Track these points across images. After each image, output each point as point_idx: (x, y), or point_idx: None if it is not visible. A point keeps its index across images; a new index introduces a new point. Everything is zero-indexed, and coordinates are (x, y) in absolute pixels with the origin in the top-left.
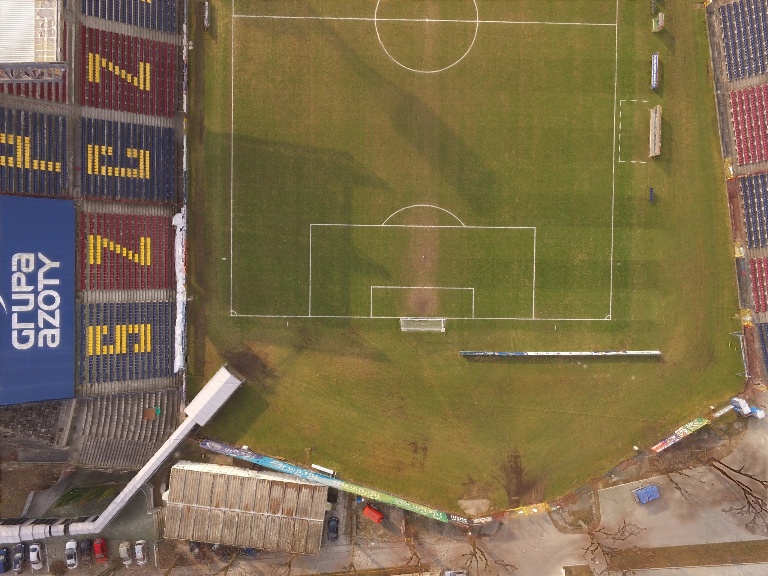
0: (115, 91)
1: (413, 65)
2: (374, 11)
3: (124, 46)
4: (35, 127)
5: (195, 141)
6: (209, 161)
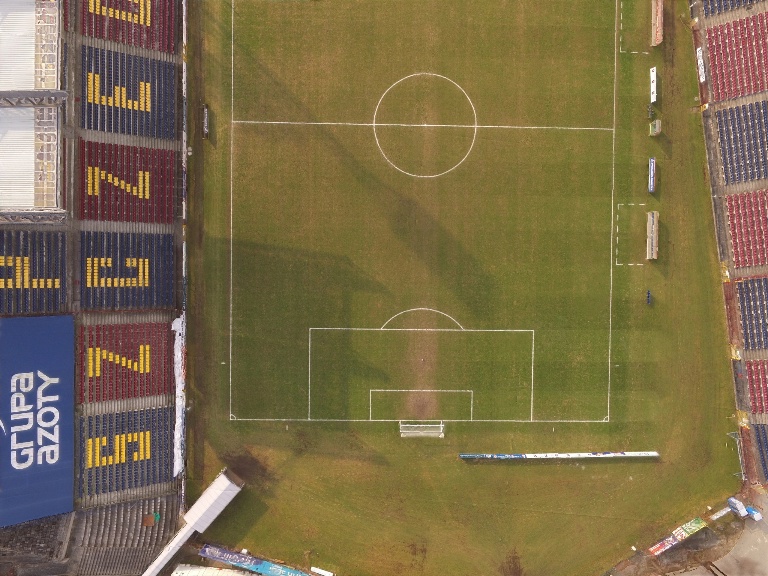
0: (114, 202)
1: (412, 170)
2: (373, 116)
3: (123, 157)
4: (34, 246)
5: (194, 246)
6: (208, 266)
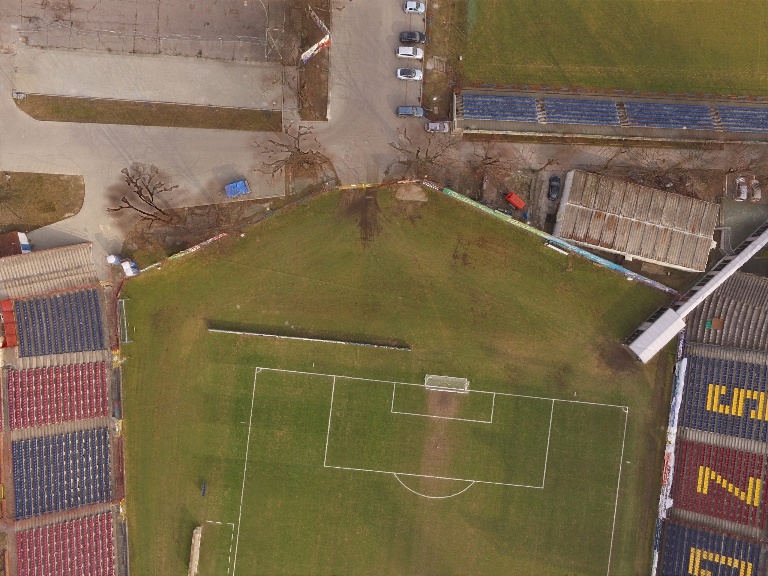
0: None
1: None
2: None
3: None
4: None
5: (642, 575)
6: (631, 556)
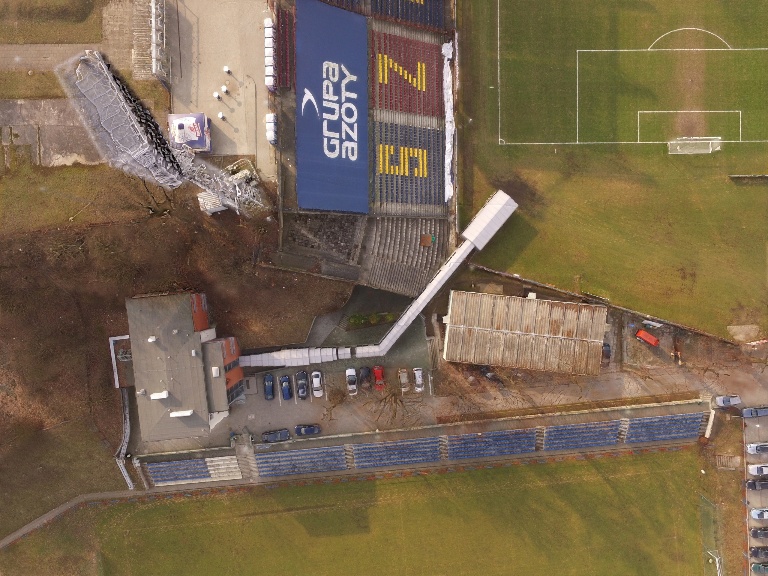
0: None
1: None
2: None
3: None
4: None
5: None
6: None
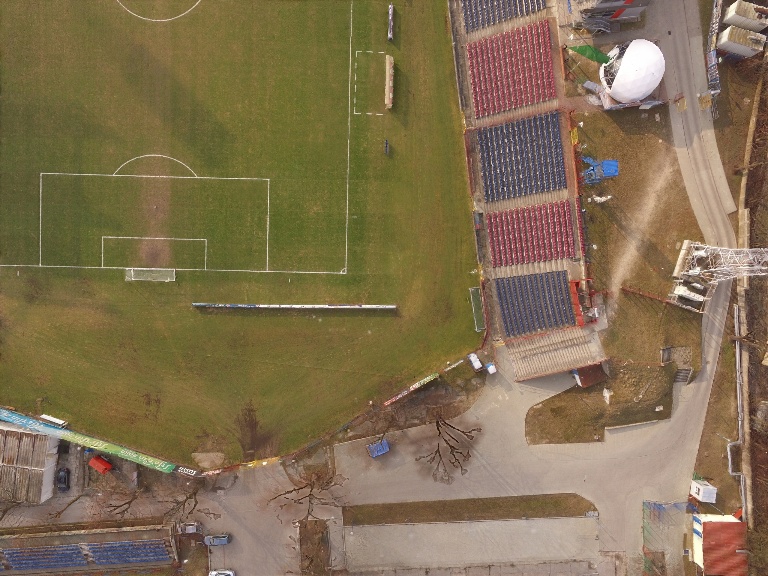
0: None
1: (144, 13)
2: None
3: None
4: None
5: None
6: None
